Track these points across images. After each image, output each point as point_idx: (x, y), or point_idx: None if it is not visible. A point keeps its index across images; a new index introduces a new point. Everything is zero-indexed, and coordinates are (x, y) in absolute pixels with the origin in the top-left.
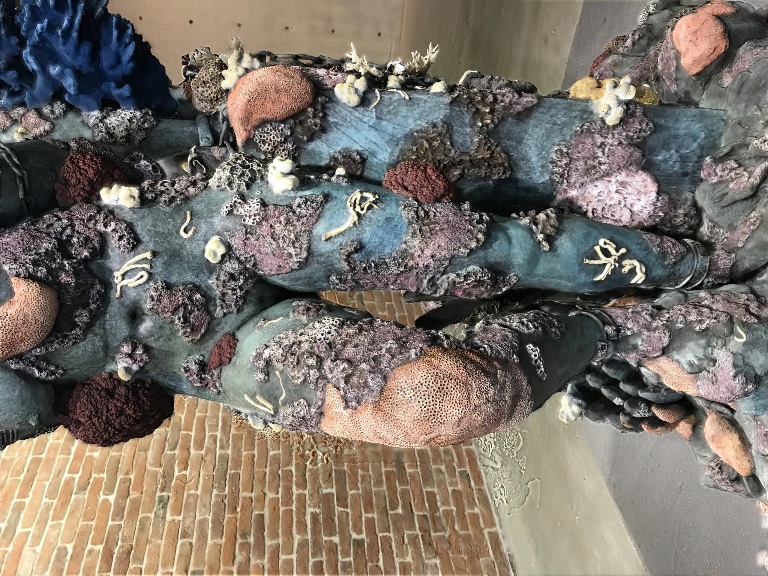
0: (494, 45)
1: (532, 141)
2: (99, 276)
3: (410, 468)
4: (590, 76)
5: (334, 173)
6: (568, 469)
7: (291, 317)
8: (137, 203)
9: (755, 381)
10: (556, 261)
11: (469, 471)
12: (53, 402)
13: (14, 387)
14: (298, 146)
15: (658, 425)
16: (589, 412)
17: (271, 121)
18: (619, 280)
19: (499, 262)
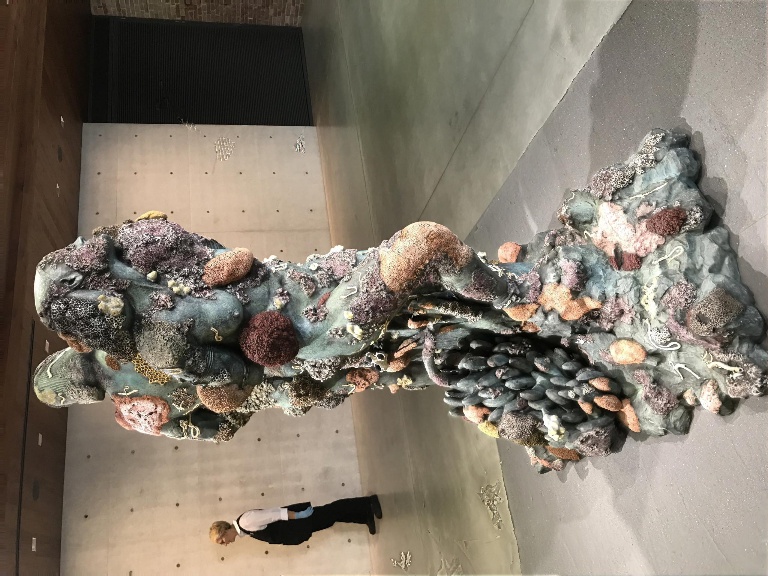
0: (448, 490)
1: None
2: None
3: None
4: None
5: None
6: None
7: None
8: None
9: None
10: None
11: None
12: None
13: (230, 295)
14: None
15: (602, 395)
16: (563, 417)
17: None
18: None
19: None
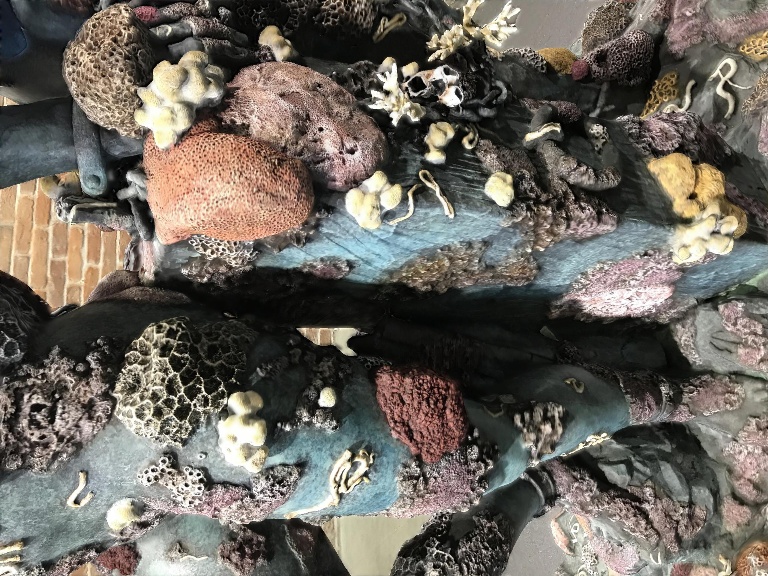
0: None
1: (577, 258)
2: None
3: None
4: None
5: (318, 397)
6: None
7: (220, 564)
8: None
9: None
10: None
11: None
12: None
13: None
14: (260, 251)
15: None
16: None
17: None
18: None
19: None
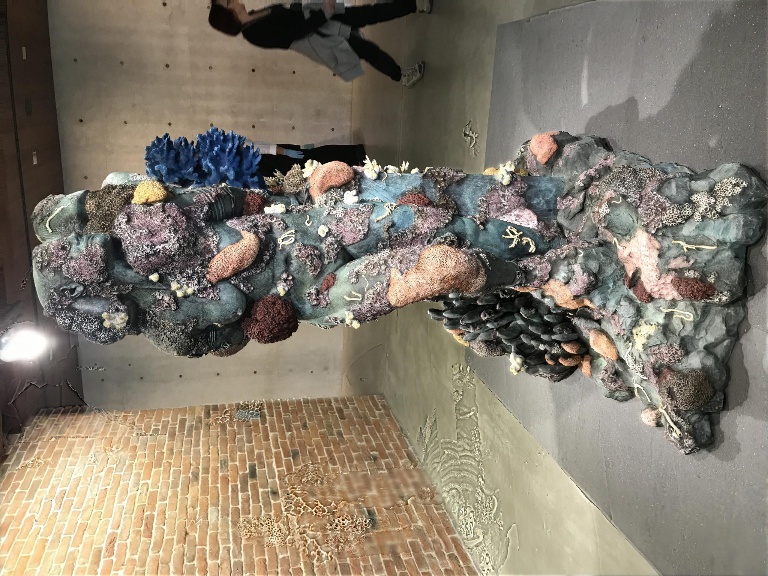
0: None
1: (467, 195)
2: (271, 240)
3: (405, 557)
4: None
5: None
6: (534, 496)
7: (364, 258)
8: (285, 210)
9: (593, 276)
10: (488, 235)
11: (457, 554)
12: (245, 308)
13: (234, 291)
14: None
15: (568, 357)
16: (527, 361)
17: (334, 187)
18: (522, 249)
19: (460, 232)
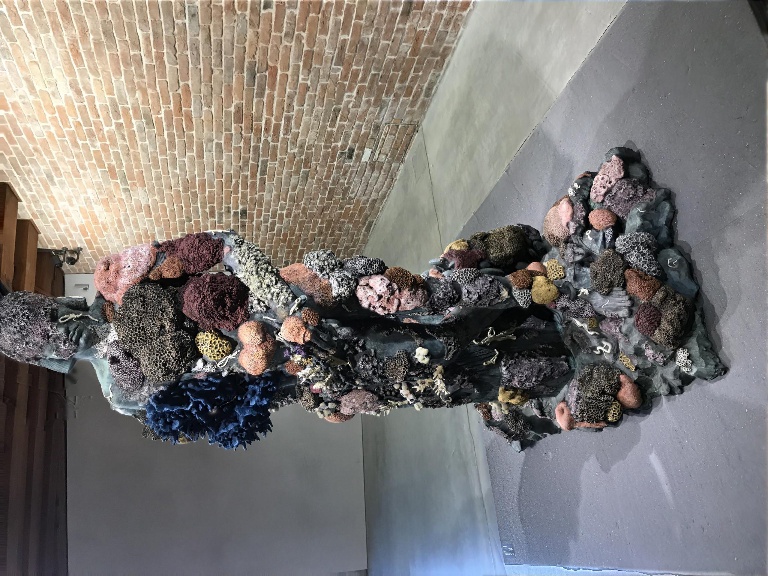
0: None
1: None
2: None
3: None
4: (636, 312)
5: None
6: None
7: None
8: None
9: None
10: None
11: None
12: None
13: None
14: None
15: None
16: None
17: None
18: None
19: None
